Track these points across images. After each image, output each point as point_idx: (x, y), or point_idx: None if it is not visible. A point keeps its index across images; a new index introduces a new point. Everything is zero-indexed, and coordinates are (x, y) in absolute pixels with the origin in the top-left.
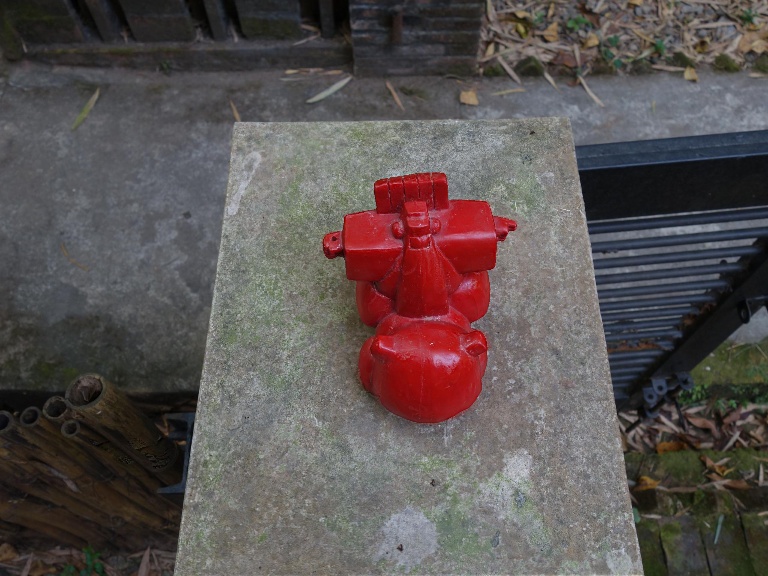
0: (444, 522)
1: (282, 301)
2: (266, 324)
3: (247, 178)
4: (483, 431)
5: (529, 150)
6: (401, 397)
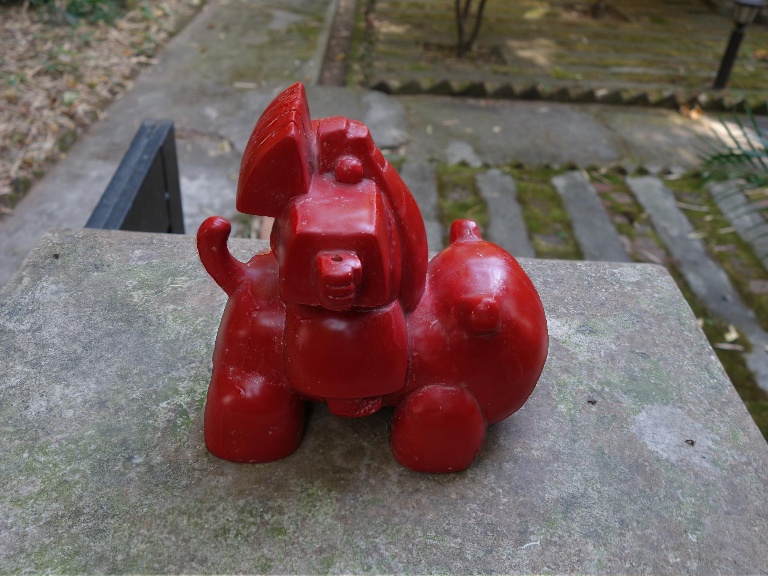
0: (639, 396)
1: None
2: None
3: None
4: None
5: (85, 263)
6: (539, 333)
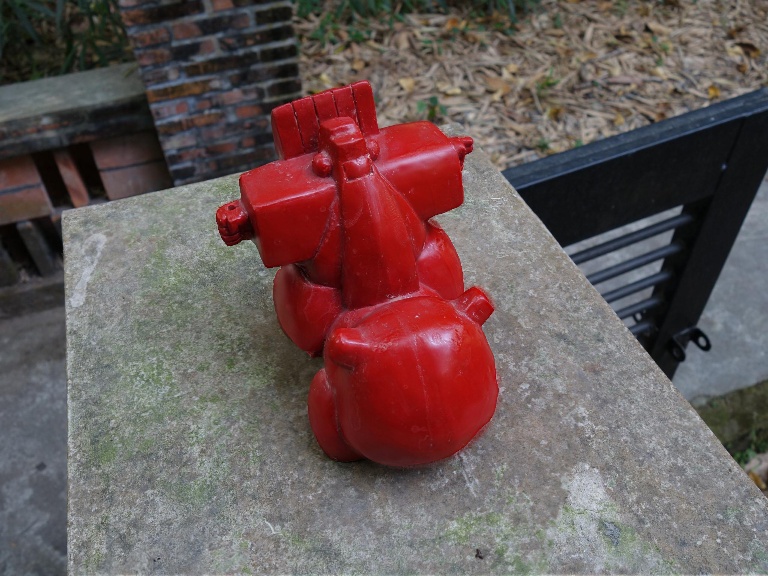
0: None
1: (174, 385)
2: (157, 420)
3: (91, 263)
4: (517, 459)
5: None
6: (396, 415)
